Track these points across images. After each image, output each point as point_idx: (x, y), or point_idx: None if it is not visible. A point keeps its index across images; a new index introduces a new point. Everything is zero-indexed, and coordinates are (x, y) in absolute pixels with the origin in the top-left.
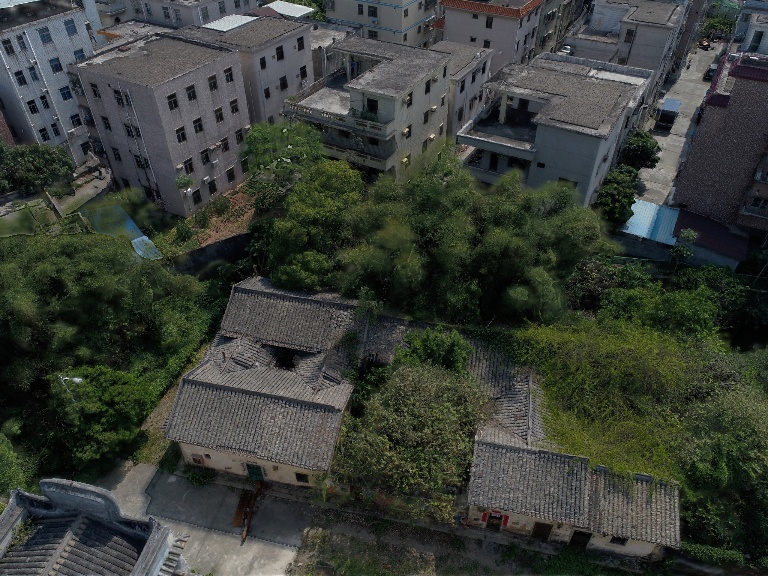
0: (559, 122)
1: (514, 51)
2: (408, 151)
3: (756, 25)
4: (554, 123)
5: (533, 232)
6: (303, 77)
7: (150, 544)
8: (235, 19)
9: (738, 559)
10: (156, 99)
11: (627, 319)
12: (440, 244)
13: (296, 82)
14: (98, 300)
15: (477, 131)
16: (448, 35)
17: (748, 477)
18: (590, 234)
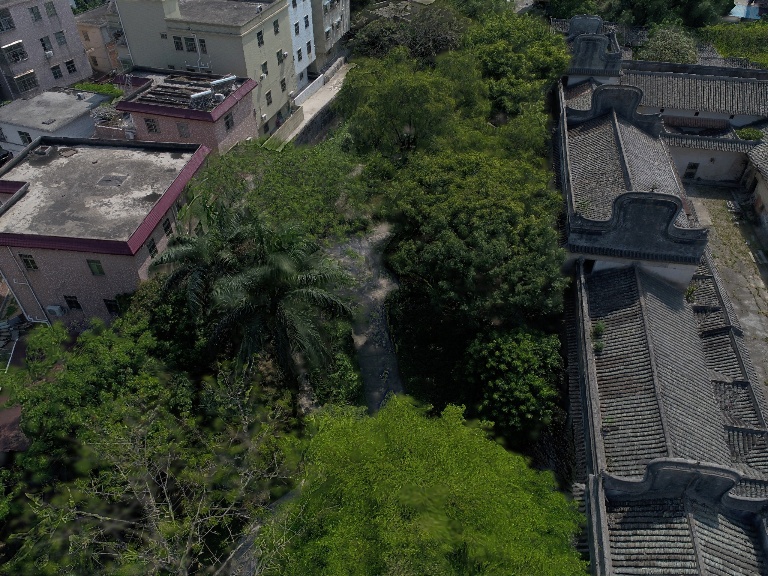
0: None
1: None
2: None
3: None
4: None
5: None
6: None
7: None
8: None
9: None
10: None
11: None
12: None
13: None
14: None
15: None
16: None
17: None
18: None
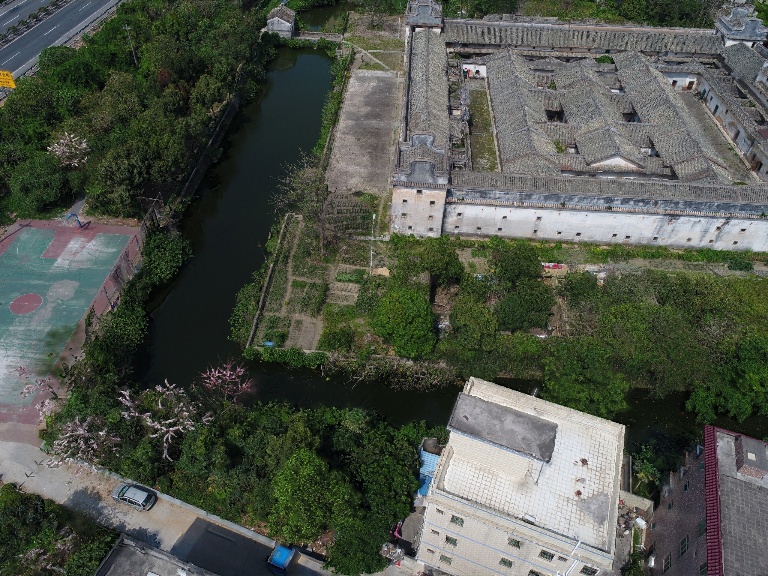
0: None
1: None
2: None
3: None
4: None
5: None
6: None
7: None
8: None
9: None
10: None
11: None
12: None
13: None
14: None
15: None
16: None
17: None
18: None
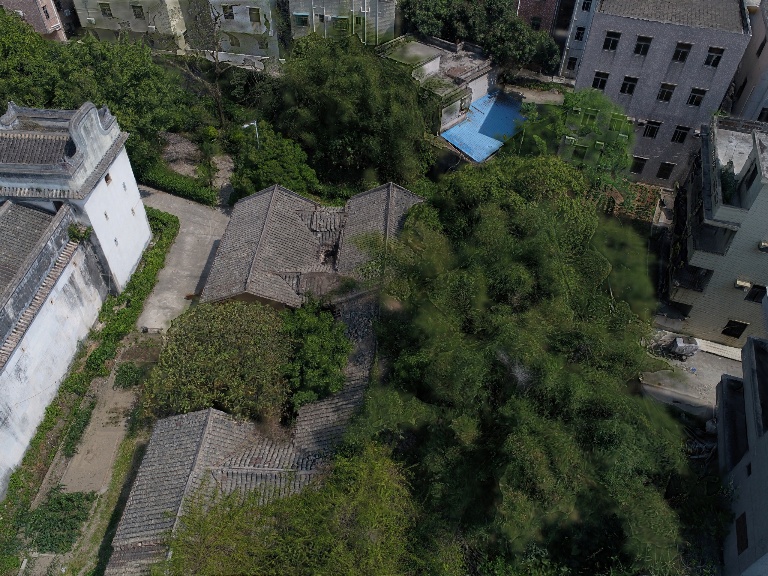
0: None
1: None
2: (767, 282)
3: None
4: None
5: (492, 384)
6: None
7: (53, 166)
8: None
9: None
10: (593, 26)
11: None
12: None
13: None
14: None
15: None
16: None
17: None
18: (540, 485)
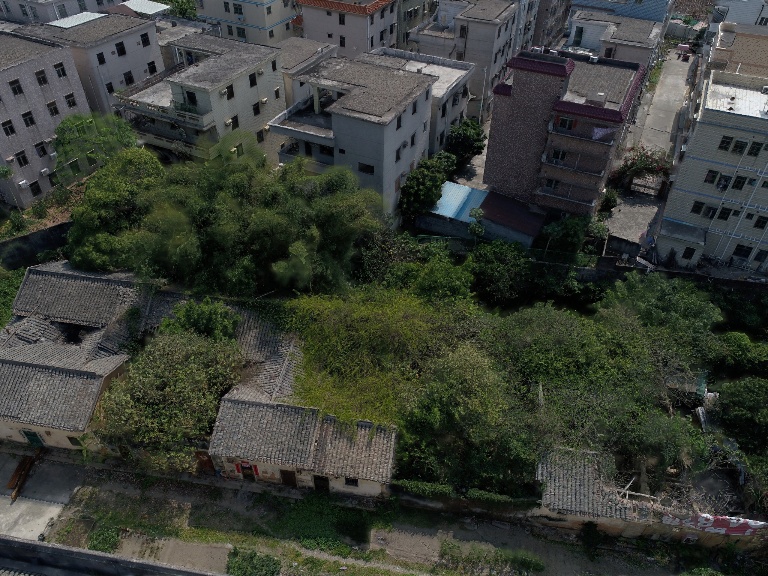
0: (350, 111)
1: (368, 46)
2: (238, 141)
3: (576, 21)
4: (345, 112)
5: (299, 210)
6: (152, 72)
7: None
8: (84, 16)
9: (447, 491)
10: None
11: (398, 289)
12: (214, 223)
13: (144, 77)
14: None
15: (291, 121)
16: (307, 31)
17: (456, 419)
18: (356, 211)
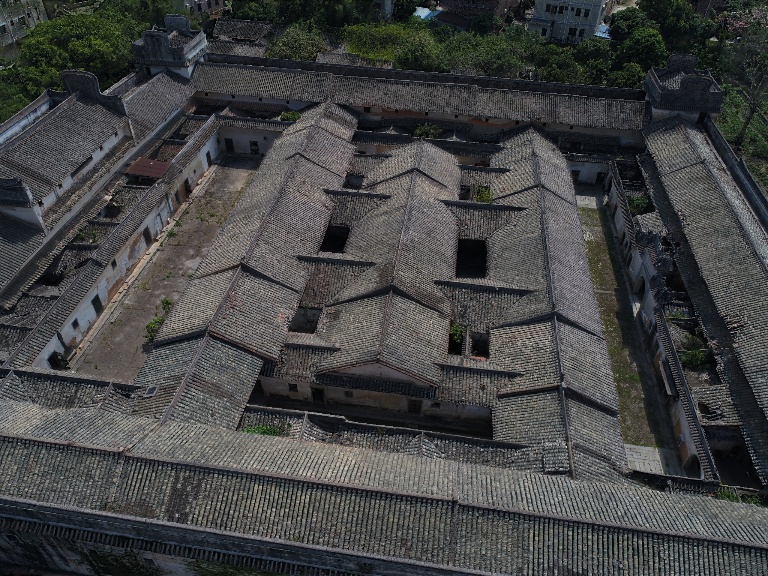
0: None
1: None
2: None
3: None
4: None
5: None
6: None
7: None
8: None
9: None
10: None
11: None
12: None
13: None
14: (159, 16)
15: None
16: None
17: (418, 57)
18: None
